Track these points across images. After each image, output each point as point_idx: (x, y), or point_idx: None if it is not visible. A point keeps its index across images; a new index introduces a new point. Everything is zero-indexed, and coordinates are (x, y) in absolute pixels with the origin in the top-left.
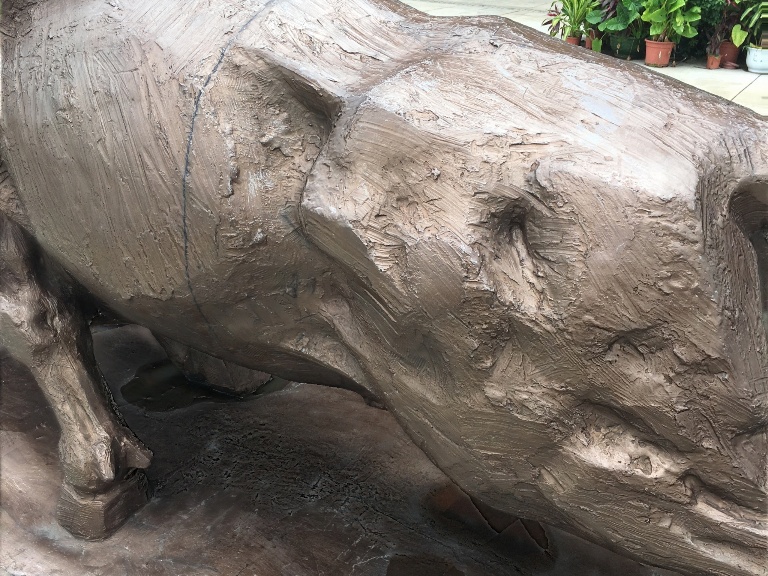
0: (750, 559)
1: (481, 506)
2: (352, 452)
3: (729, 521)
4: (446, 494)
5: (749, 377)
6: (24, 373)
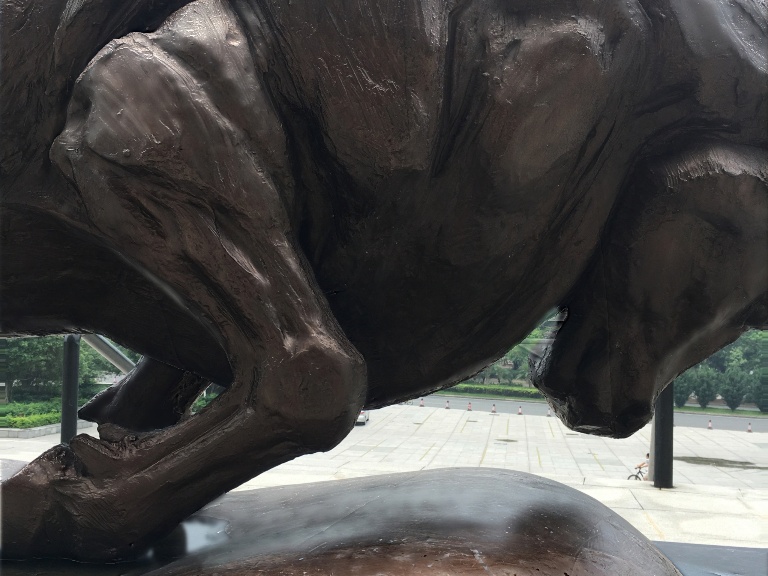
0: None
1: None
2: None
3: None
4: None
5: None
6: None
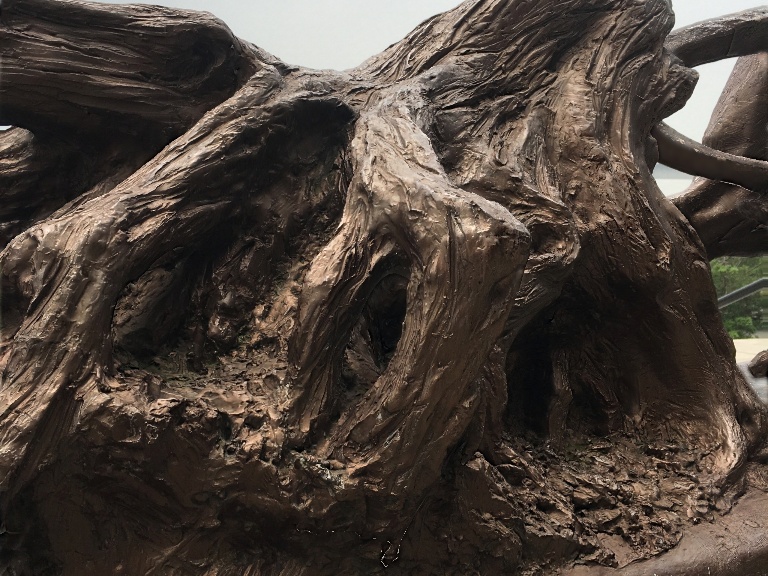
0: None
1: None
2: None
3: None
4: None
5: (709, 123)
6: None
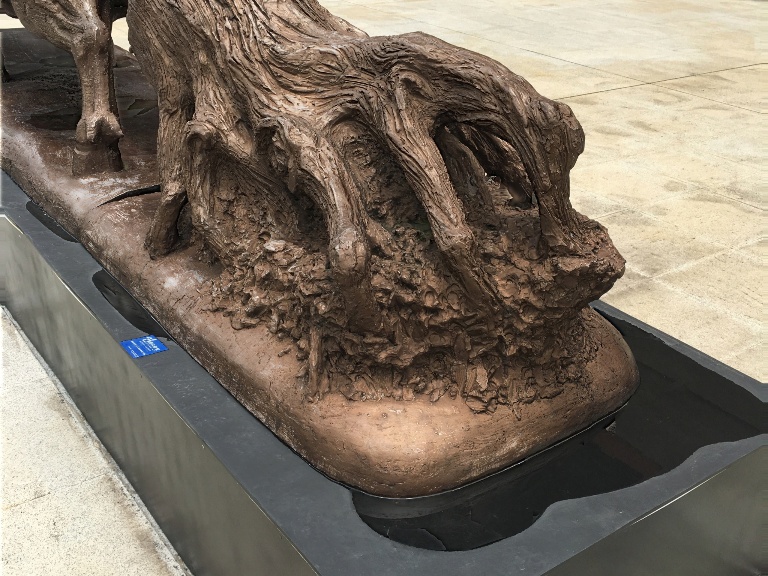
0: (69, 35)
1: None
2: None
3: (64, 19)
4: (127, 100)
5: None
6: (2, 45)
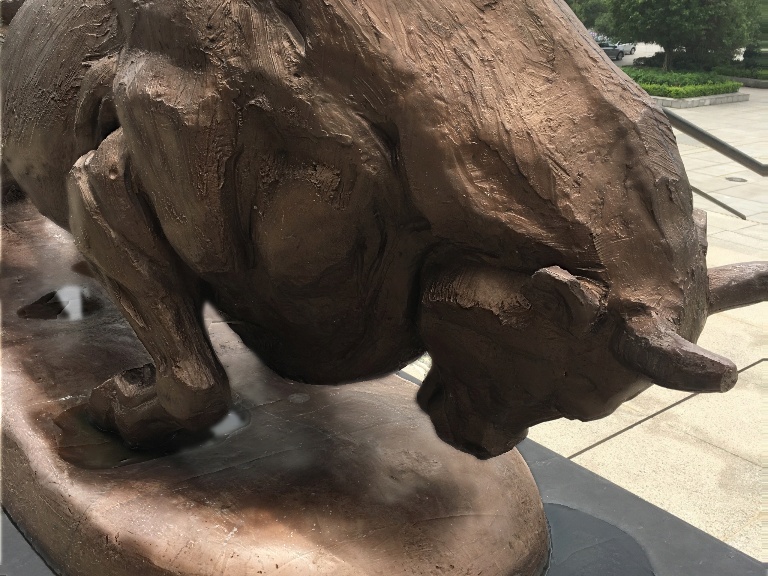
0: None
1: (58, 311)
2: (104, 335)
3: None
4: (69, 319)
5: None
6: (345, 421)
